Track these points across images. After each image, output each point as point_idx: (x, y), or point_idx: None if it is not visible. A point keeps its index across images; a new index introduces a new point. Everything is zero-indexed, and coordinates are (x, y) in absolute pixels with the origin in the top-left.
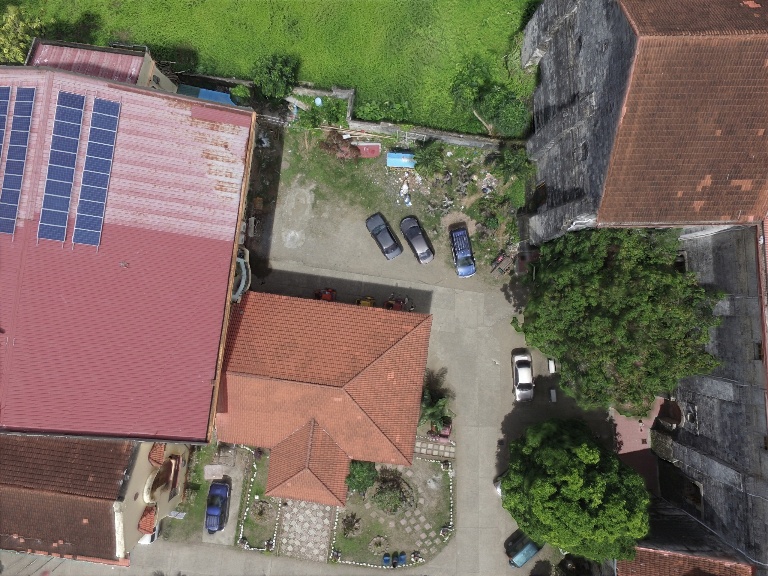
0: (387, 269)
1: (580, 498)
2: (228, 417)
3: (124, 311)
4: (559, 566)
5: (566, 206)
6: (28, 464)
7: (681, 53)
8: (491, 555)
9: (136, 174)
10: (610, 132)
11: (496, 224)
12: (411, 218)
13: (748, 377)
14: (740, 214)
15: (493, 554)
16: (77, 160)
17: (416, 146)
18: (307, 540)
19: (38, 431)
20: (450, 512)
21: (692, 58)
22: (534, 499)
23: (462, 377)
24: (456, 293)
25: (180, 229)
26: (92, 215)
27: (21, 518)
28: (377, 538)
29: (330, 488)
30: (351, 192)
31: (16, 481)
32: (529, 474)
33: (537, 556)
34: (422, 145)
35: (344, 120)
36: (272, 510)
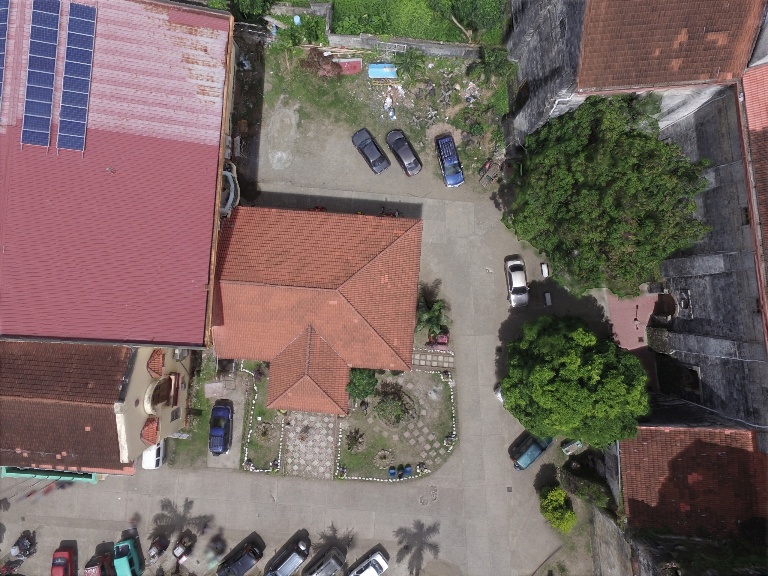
0: (376, 184)
1: (578, 377)
2: (225, 330)
3: (113, 217)
4: (564, 467)
5: (548, 86)
6: (26, 376)
7: None
8: (496, 462)
9: (117, 79)
10: None
11: (481, 130)
12: (396, 131)
13: (737, 244)
14: (719, 71)
15: (498, 461)
16: (56, 65)
17: None
18: (312, 458)
19: (34, 338)
20: (452, 422)
21: None
22: (533, 385)
23: (457, 287)
24: (446, 204)
25: (164, 134)
26: (75, 120)
27: (22, 431)
28: (381, 452)
29: (331, 396)
30: (335, 109)
31: (15, 392)
32: (527, 365)
33: (541, 460)
34: None
35: (324, 37)
36: (275, 431)
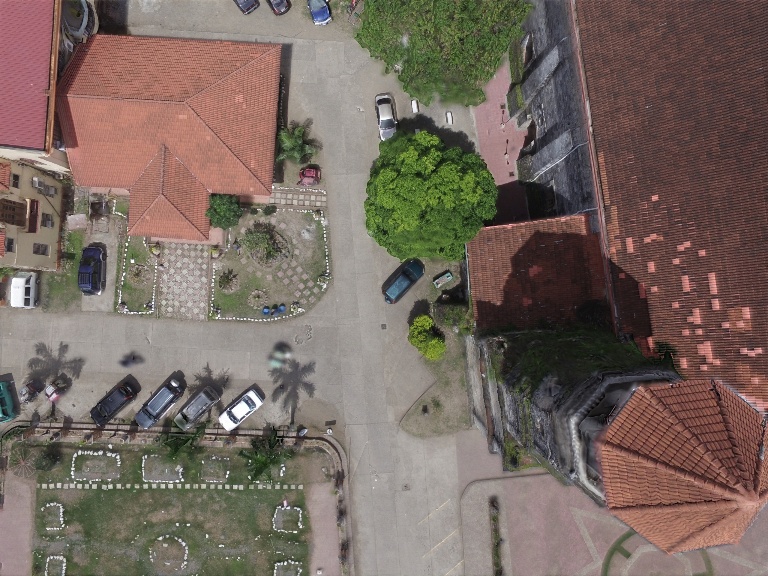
0: (245, 25)
1: (417, 172)
2: (80, 153)
3: None
4: (436, 302)
5: None
6: None
7: None
8: (370, 299)
9: None
10: None
11: None
12: None
13: (568, 29)
14: None
15: (372, 298)
16: None
17: None
18: (186, 300)
19: None
20: (326, 260)
21: None
22: (378, 187)
23: (328, 126)
24: (316, 44)
25: None
26: None
27: None
28: (255, 292)
29: (189, 219)
30: None
31: None
32: None
33: (415, 296)
34: None
35: None
36: (149, 273)
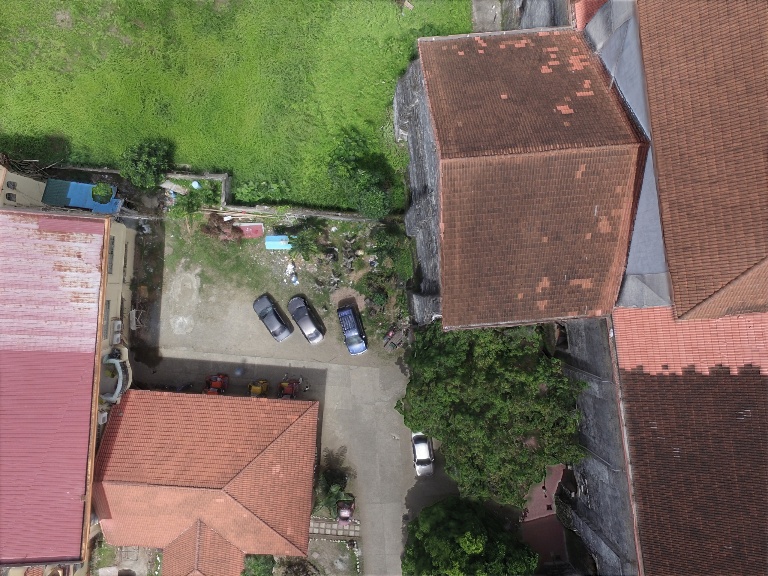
0: (279, 350)
1: None
2: (113, 522)
3: None
4: None
5: (425, 300)
6: None
7: (487, 172)
8: None
9: None
10: None
11: (383, 300)
12: (298, 298)
13: (619, 462)
14: (586, 309)
15: None
16: None
17: (300, 223)
18: None
19: None
20: None
21: (500, 175)
22: None
23: (362, 454)
24: (351, 369)
25: (36, 346)
26: None
27: None
28: None
29: None
30: (237, 274)
31: None
32: (419, 563)
33: None
34: (306, 222)
35: None
36: None
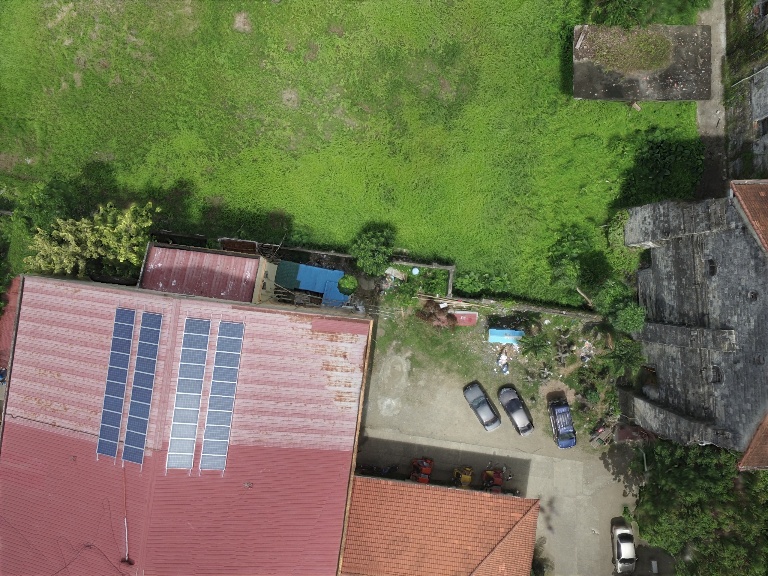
0: (484, 437)
1: None
2: None
3: (248, 530)
4: None
5: (695, 426)
6: None
7: None
8: None
9: (259, 393)
10: (758, 383)
11: (598, 398)
12: (510, 389)
13: None
14: None
15: None
16: (203, 386)
17: (513, 314)
18: None
19: None
20: None
21: None
22: None
23: (561, 546)
24: (554, 462)
25: (301, 444)
26: (218, 439)
27: None
28: None
29: None
30: (448, 360)
31: None
32: None
33: None
34: (519, 313)
35: (441, 289)
36: None
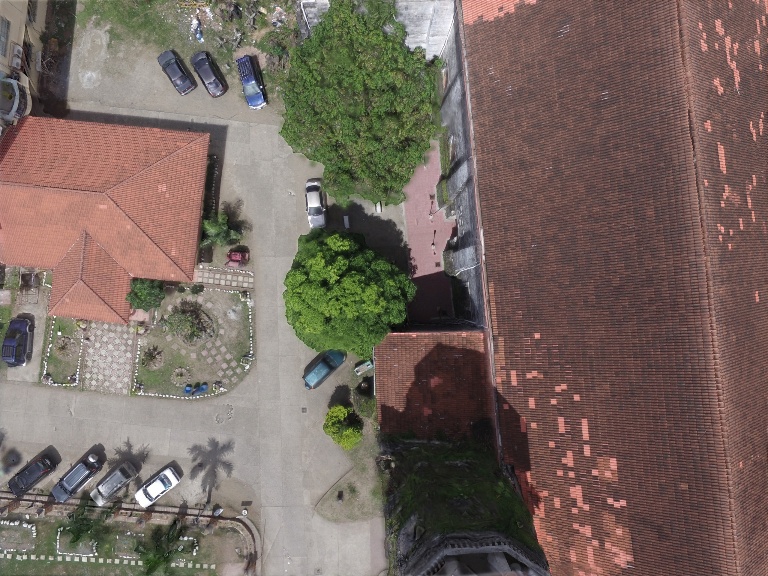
0: (182, 105)
1: (323, 279)
2: (3, 234)
3: None
4: (356, 389)
5: None
6: None
7: None
8: (291, 382)
9: None
10: None
11: (280, 51)
12: (201, 52)
13: None
14: None
15: (293, 381)
16: None
17: None
18: (110, 374)
19: None
20: (250, 341)
21: None
22: None
23: (259, 209)
24: (251, 126)
25: None
26: None
27: None
28: (178, 369)
29: (108, 303)
30: (145, 31)
31: None
32: None
33: (336, 381)
34: None
35: None
36: (74, 345)
